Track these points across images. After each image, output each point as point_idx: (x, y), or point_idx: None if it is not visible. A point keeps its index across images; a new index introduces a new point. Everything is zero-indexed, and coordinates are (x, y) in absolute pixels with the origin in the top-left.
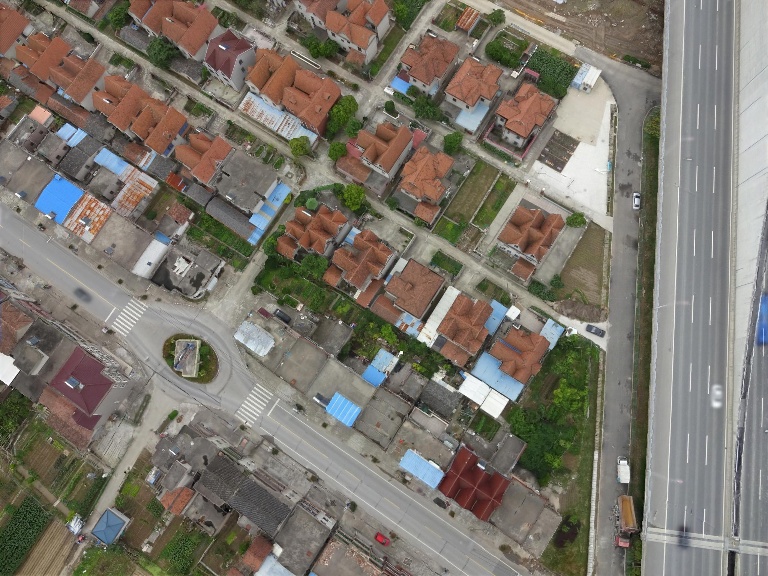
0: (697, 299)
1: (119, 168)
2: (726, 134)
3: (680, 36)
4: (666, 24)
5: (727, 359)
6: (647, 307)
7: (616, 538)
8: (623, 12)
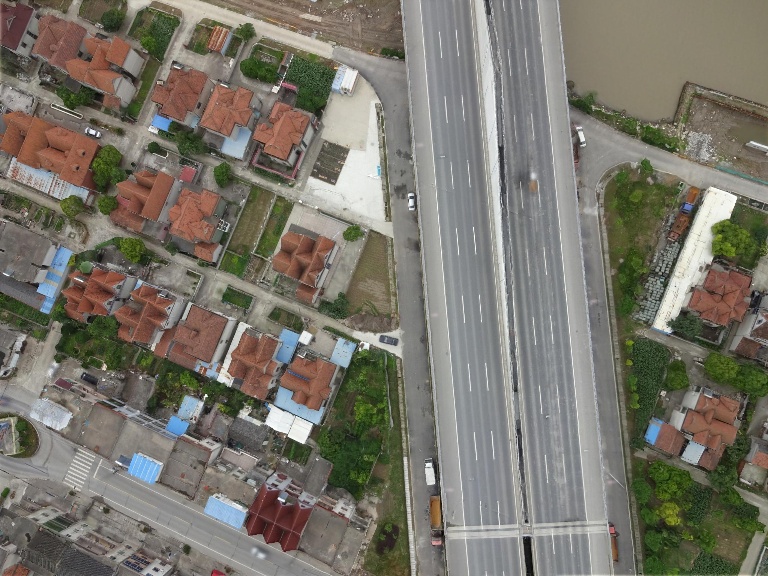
0: (466, 299)
1: None
2: (475, 123)
3: (418, 26)
4: (403, 15)
5: (501, 353)
6: None
7: None
8: (377, 1)
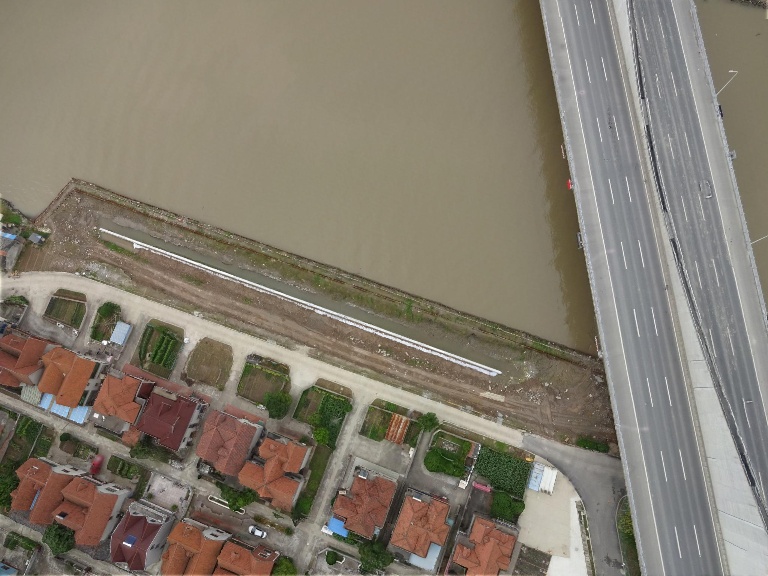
0: None
1: None
2: (713, 560)
3: (637, 444)
4: (618, 432)
5: None
6: None
7: None
8: (565, 380)
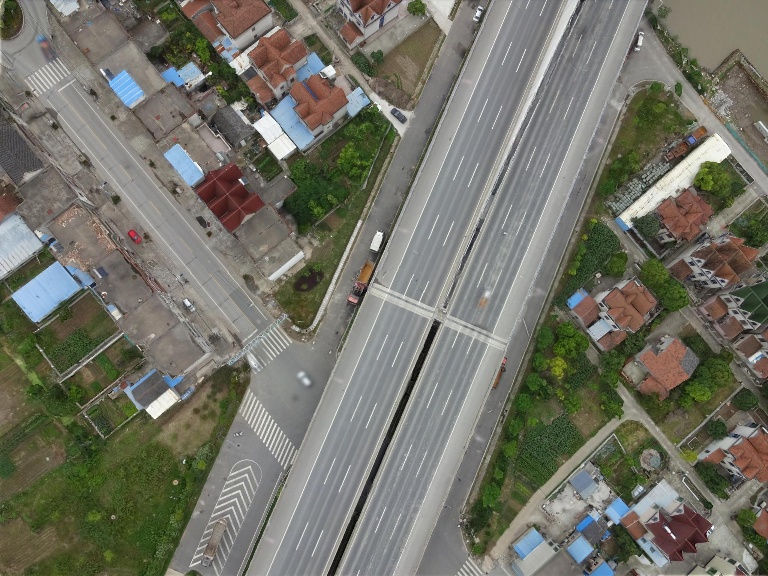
0: (490, 103)
1: None
2: None
3: None
4: None
5: (495, 162)
6: None
7: (349, 294)
8: None
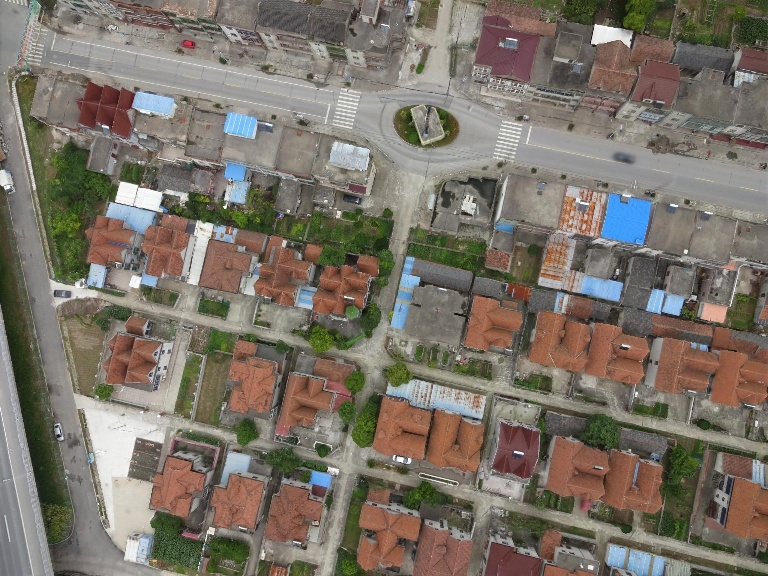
0: None
1: (589, 285)
2: None
3: None
4: None
5: None
6: (25, 333)
7: None
8: None
